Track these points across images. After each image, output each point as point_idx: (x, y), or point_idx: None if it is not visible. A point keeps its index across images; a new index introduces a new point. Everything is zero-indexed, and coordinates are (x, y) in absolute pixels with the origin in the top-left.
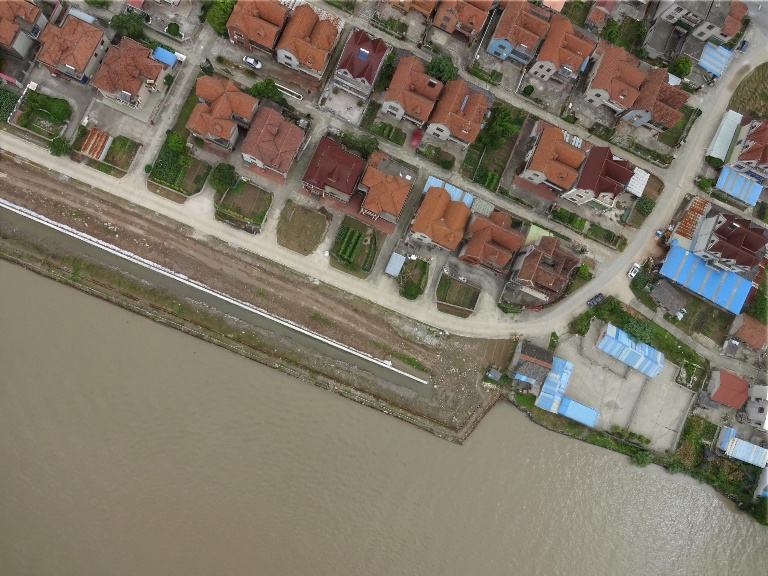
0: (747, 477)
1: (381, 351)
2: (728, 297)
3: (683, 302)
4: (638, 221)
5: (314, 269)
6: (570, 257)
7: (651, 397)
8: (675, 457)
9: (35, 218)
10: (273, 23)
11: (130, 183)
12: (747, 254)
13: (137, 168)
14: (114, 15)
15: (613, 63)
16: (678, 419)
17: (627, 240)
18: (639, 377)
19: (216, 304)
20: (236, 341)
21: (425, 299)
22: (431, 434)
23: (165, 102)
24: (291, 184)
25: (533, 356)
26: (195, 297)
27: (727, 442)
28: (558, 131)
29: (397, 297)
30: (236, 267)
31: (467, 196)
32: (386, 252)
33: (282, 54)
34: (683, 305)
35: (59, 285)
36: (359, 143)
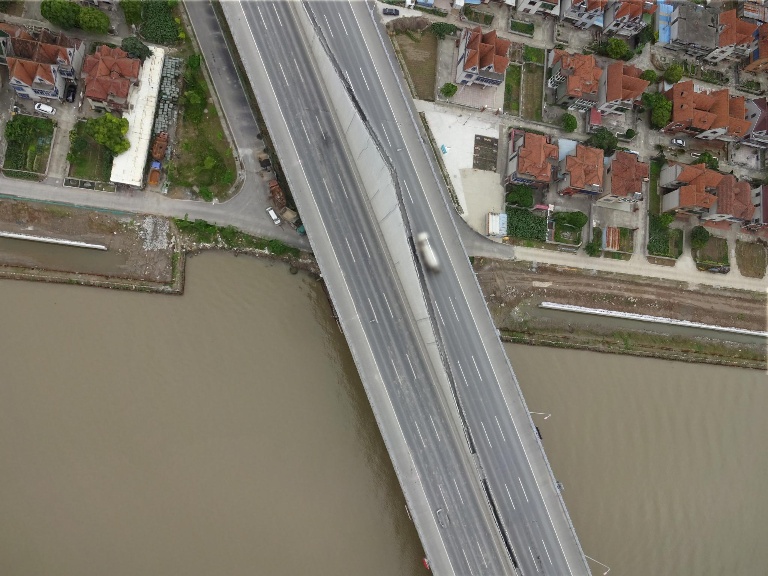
0: None
1: None
2: None
3: None
4: None
5: None
6: None
7: None
8: None
9: (587, 310)
10: (702, 110)
11: (636, 262)
12: None
13: (636, 249)
14: (593, 135)
15: None
16: None
17: None
18: None
19: (713, 335)
20: (742, 358)
21: None
22: None
23: None
24: (734, 228)
25: None
26: (699, 335)
27: None
28: None
29: None
30: (720, 303)
31: None
32: None
33: (711, 131)
34: None
35: (618, 356)
36: None
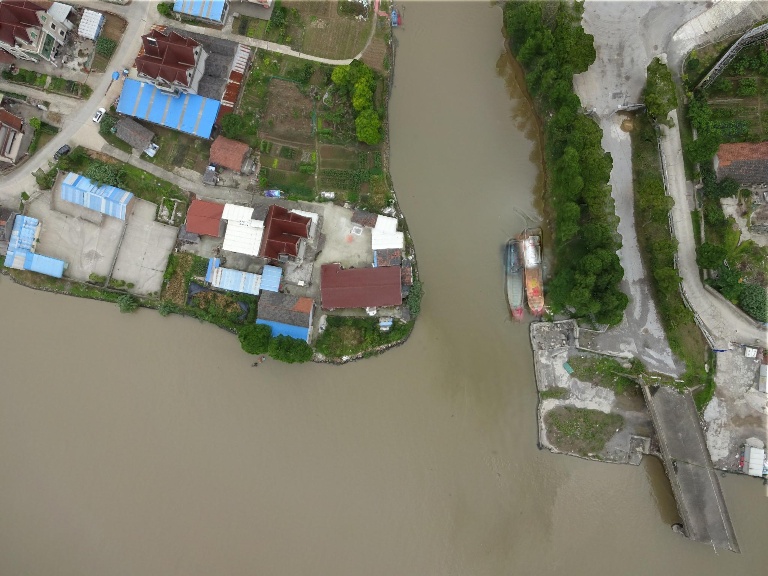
0: (240, 307)
1: None
2: (194, 122)
3: (147, 136)
4: (102, 65)
5: None
6: None
7: (133, 241)
8: (164, 298)
9: None
10: None
11: None
12: (168, 67)
13: None
14: None
15: None
16: (165, 259)
17: (91, 86)
18: (118, 222)
19: None
20: None
21: None
22: None
23: None
24: None
25: None
26: None
27: (211, 273)
28: None
29: None
30: None
31: None
32: None
33: None
34: (145, 139)
35: None
36: None
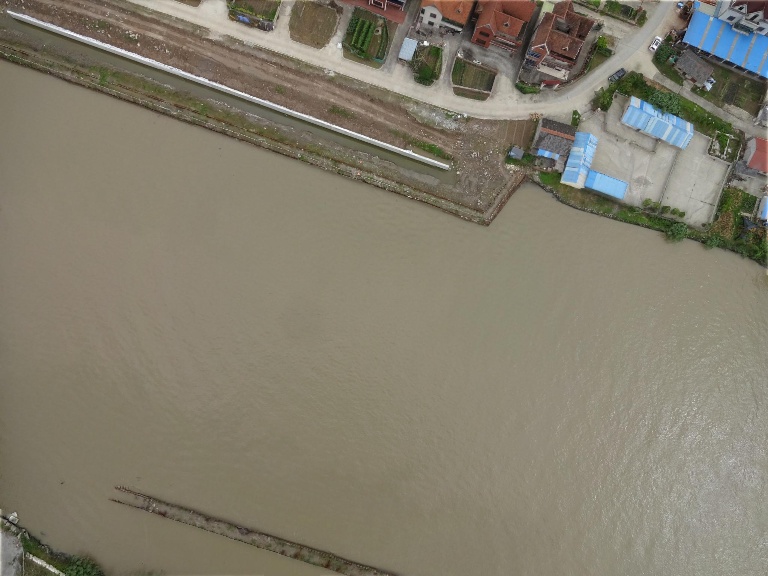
0: None
1: (401, 140)
2: (759, 61)
3: (710, 70)
4: None
5: (328, 61)
6: (584, 18)
7: (683, 171)
8: (713, 230)
9: (62, 29)
10: None
11: None
12: None
13: None
14: None
15: None
16: (714, 192)
17: (646, 14)
18: (669, 152)
19: (237, 104)
20: (258, 135)
21: (441, 85)
22: (457, 217)
23: None
24: None
25: (554, 129)
26: (216, 98)
27: (767, 210)
28: None
29: (412, 84)
30: (253, 65)
31: None
32: (398, 41)
33: None
34: (710, 72)
35: (89, 92)
36: None
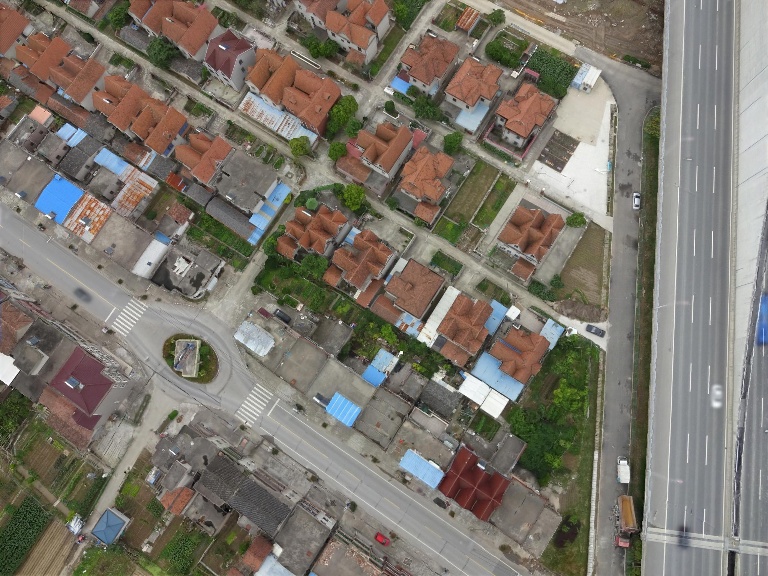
0: None
1: None
2: None
3: None
4: None
5: None
6: None
7: None
8: None
9: None
10: (300, 90)
11: None
12: None
13: (439, 7)
14: None
15: (2, 33)
16: None
17: None
18: None
19: None
20: None
21: None
22: None
23: None
24: None
25: None
26: None
27: None
28: None
29: None
30: None
31: None
32: None
33: None
34: None
35: None
36: (249, 1)
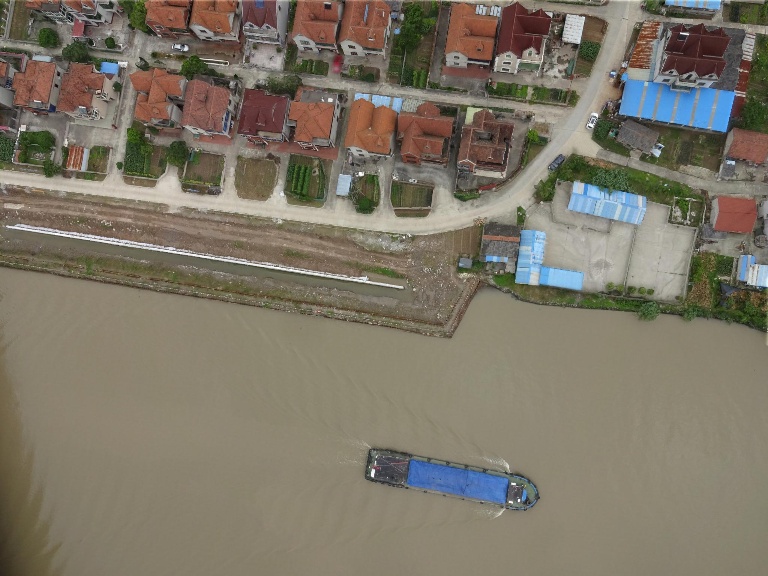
0: None
1: (355, 269)
2: (708, 116)
3: (655, 137)
4: (586, 69)
5: (275, 211)
6: (503, 124)
7: (645, 245)
8: (689, 301)
9: (50, 232)
10: (181, 6)
11: (111, 182)
12: (706, 61)
13: (113, 168)
14: (63, 49)
15: None
16: (683, 261)
17: (578, 92)
18: (626, 228)
19: (204, 265)
20: (225, 291)
21: (382, 210)
22: (419, 334)
23: (121, 106)
24: (238, 142)
25: (497, 234)
26: (186, 263)
27: (746, 271)
28: (462, 6)
29: (355, 215)
30: (210, 228)
31: (396, 101)
32: (335, 177)
33: (197, 30)
34: (655, 140)
35: (80, 281)
36: (283, 85)
